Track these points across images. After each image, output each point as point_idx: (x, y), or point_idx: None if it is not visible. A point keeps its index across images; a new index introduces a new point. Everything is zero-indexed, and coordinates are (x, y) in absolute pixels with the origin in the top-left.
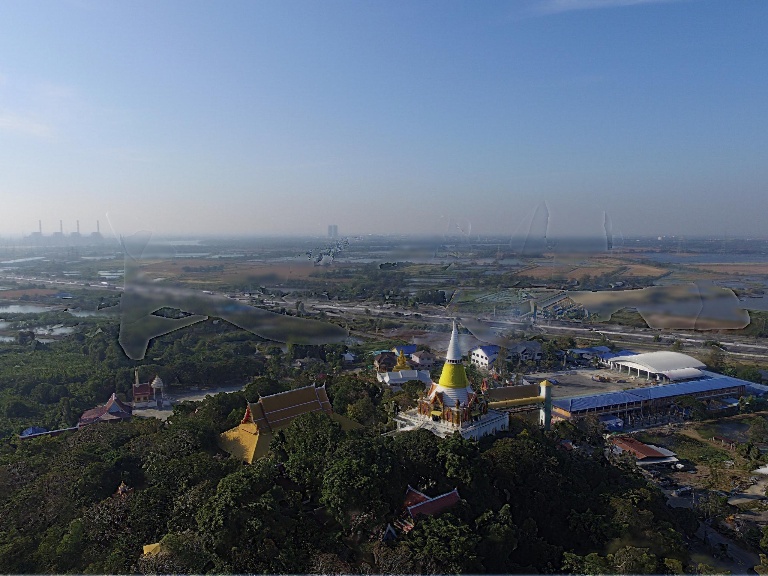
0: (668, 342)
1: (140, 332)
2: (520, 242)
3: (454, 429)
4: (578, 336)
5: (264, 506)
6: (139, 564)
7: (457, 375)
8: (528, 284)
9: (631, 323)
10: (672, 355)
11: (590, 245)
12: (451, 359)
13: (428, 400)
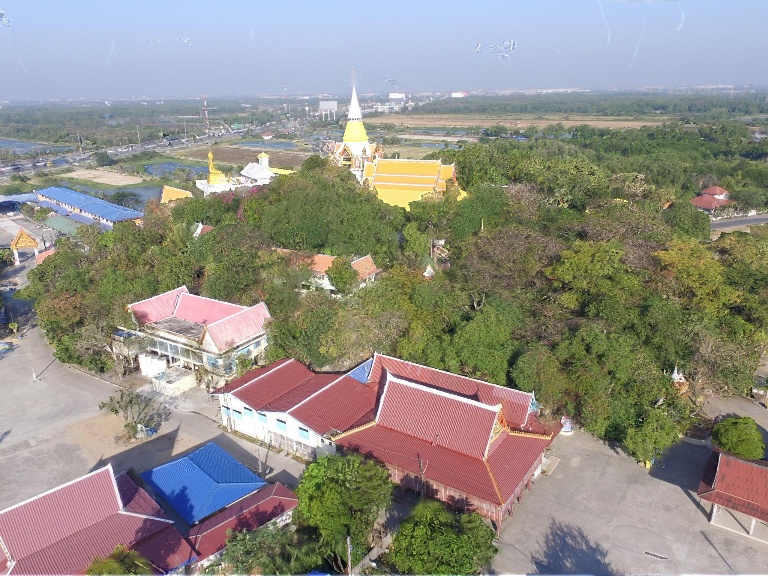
0: None
1: (617, 55)
2: None
3: None
4: None
5: None
6: None
7: None
8: None
9: None
10: None
11: None
12: None
13: (366, 155)
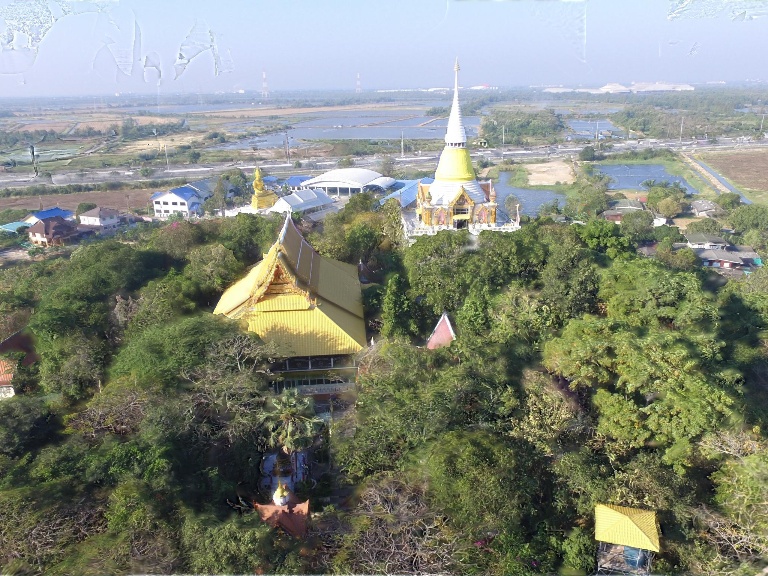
0: (308, 166)
1: (506, 6)
2: (110, 66)
3: (510, 227)
4: (217, 174)
5: (712, 350)
6: (733, 555)
7: (470, 162)
8: (57, 139)
9: (242, 158)
10: (353, 170)
11: (197, 69)
12: (461, 141)
13: (439, 204)
